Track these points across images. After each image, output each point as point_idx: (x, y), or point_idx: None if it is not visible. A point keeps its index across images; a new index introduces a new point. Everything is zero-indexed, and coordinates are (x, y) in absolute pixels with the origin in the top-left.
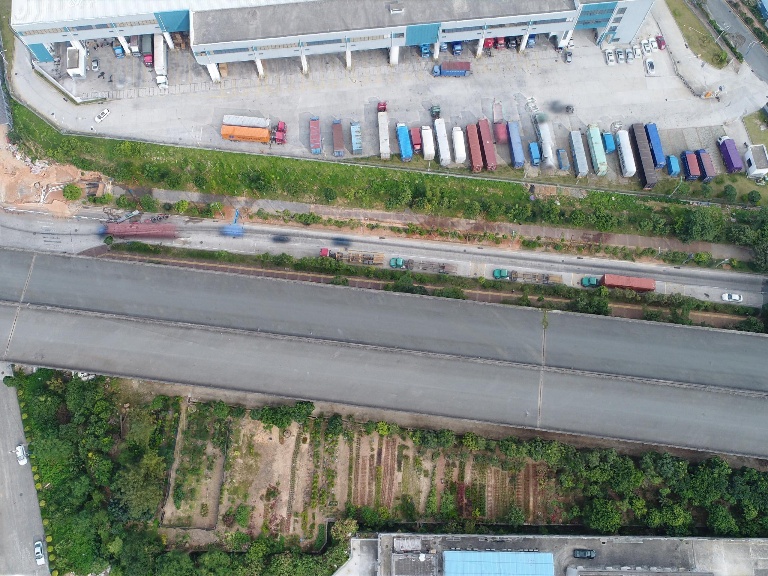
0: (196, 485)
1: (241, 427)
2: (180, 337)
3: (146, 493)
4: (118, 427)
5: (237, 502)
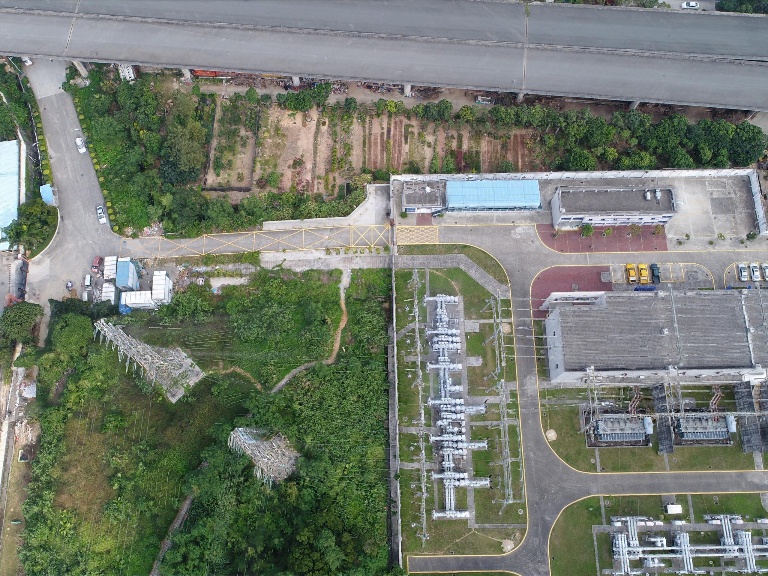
0: (232, 159)
1: (269, 115)
2: (214, 35)
3: (192, 145)
4: (163, 118)
5: (268, 171)
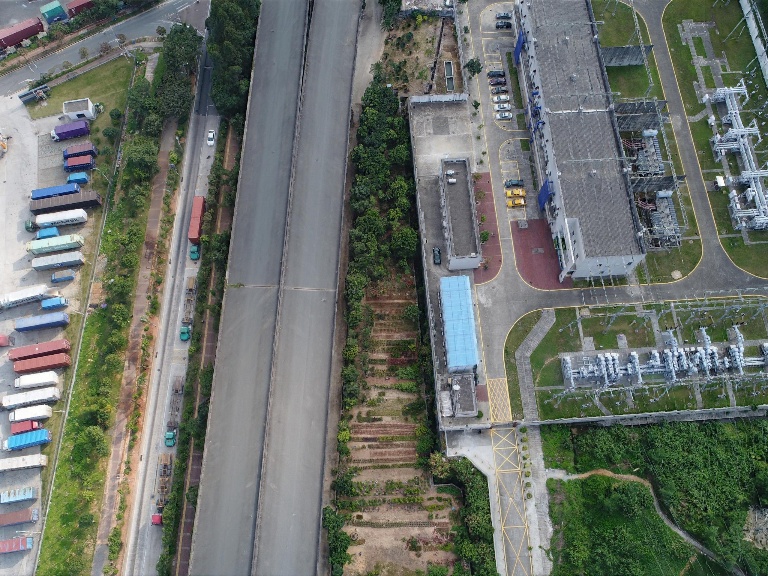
0: None
1: None
2: None
3: None
4: None
5: None
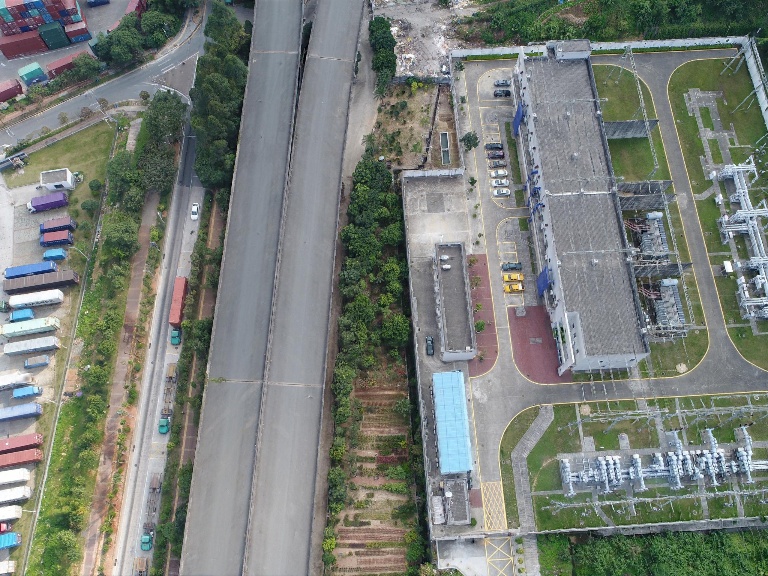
0: None
1: None
2: None
3: None
4: None
5: None
